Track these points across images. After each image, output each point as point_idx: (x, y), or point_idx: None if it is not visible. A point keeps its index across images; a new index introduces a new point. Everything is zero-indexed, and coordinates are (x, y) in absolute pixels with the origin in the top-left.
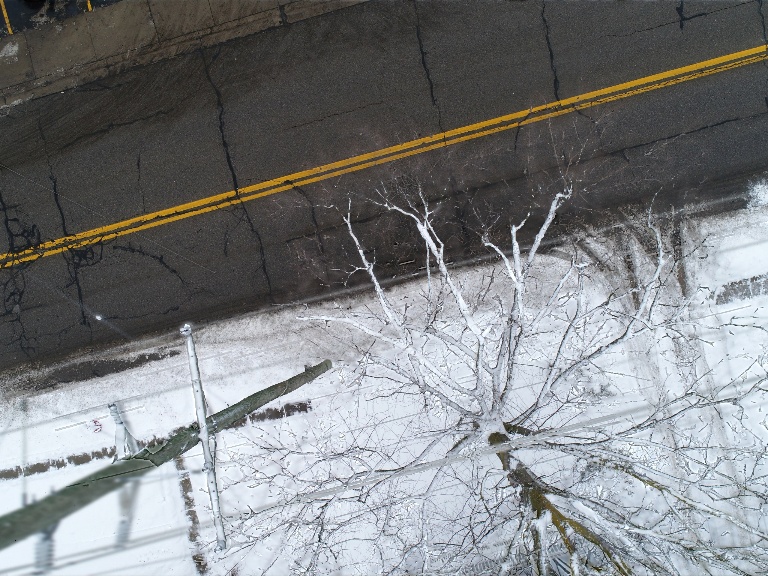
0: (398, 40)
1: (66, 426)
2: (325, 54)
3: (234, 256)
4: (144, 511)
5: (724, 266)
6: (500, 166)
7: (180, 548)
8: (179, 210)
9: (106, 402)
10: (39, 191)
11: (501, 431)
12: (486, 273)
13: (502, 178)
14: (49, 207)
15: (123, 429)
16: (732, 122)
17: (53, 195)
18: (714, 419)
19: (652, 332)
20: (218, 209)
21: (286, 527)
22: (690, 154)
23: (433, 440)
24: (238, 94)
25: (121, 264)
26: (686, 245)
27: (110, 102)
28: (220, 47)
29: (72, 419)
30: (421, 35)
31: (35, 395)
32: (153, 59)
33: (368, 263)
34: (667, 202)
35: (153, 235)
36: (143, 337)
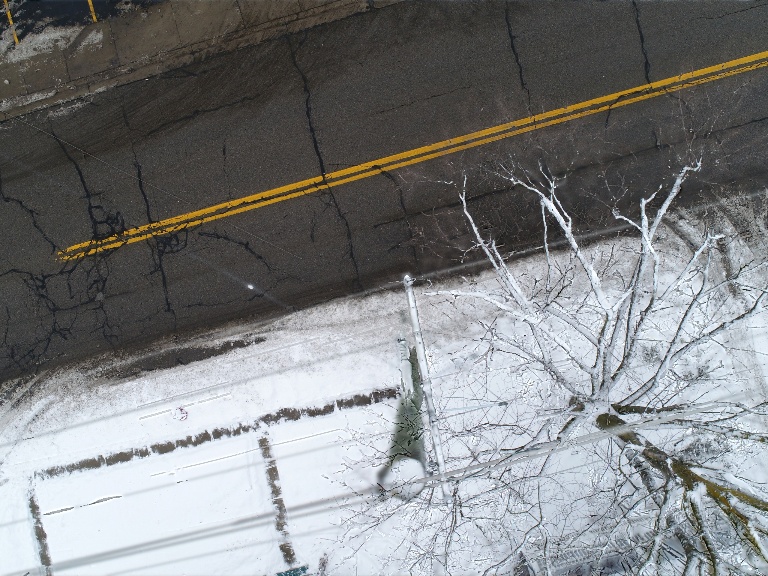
0: (486, 24)
1: (151, 414)
2: (413, 39)
3: (321, 242)
4: (231, 500)
5: None
6: None
7: (267, 537)
8: (265, 196)
9: (191, 390)
10: (123, 178)
11: (610, 412)
12: None
13: (593, 161)
14: (133, 194)
15: (409, 365)
16: None
17: (137, 182)
18: None
19: None
20: (305, 194)
21: (405, 508)
22: None
23: (552, 419)
24: (325, 79)
25: (206, 251)
26: None
27: (195, 88)
28: (306, 33)
29: (157, 407)
30: (510, 19)
31: (118, 383)
32: (239, 45)
33: (483, 241)
34: (760, 184)
35: (239, 221)
36: (228, 324)
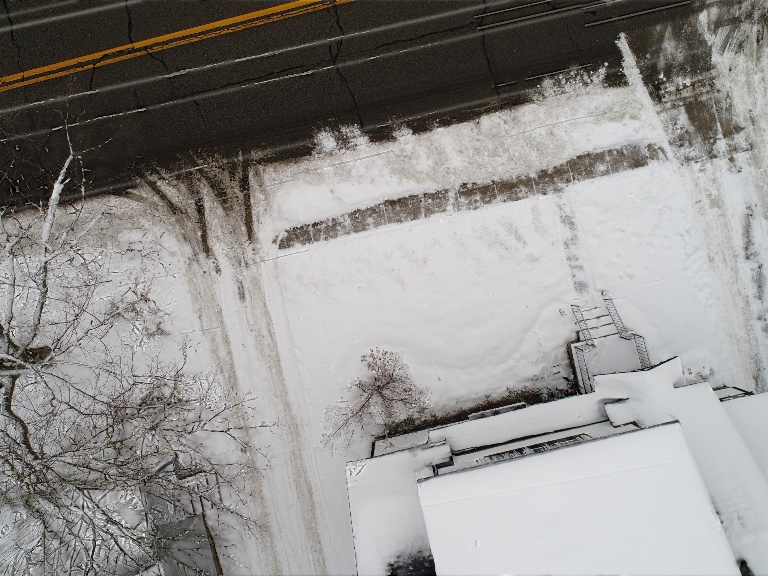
0: None
1: None
2: None
3: None
4: None
5: (277, 210)
6: (76, 107)
7: None
8: None
9: None
10: None
11: None
12: (63, 213)
13: None
14: None
15: None
16: (297, 69)
17: None
18: (273, 361)
19: (217, 275)
20: None
21: None
22: (257, 100)
23: None
24: None
25: None
26: (252, 190)
27: None
28: None
29: None
30: None
31: None
32: None
33: None
34: (236, 147)
35: None
36: None
